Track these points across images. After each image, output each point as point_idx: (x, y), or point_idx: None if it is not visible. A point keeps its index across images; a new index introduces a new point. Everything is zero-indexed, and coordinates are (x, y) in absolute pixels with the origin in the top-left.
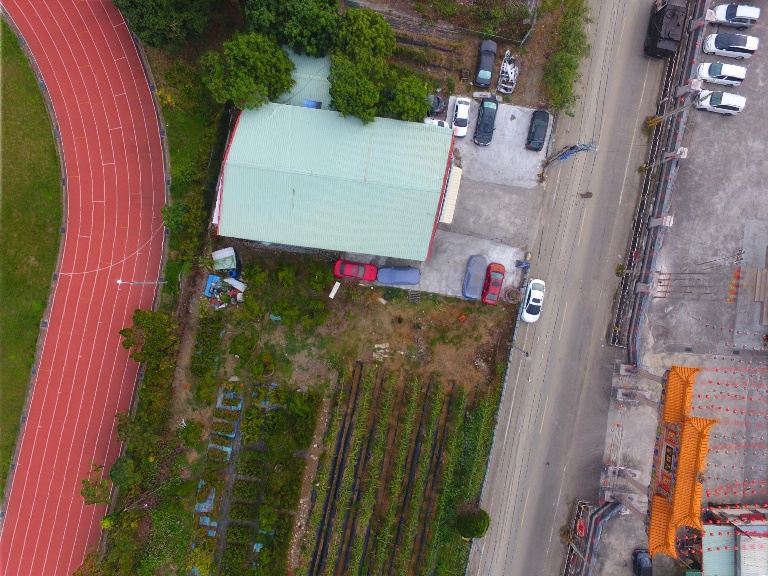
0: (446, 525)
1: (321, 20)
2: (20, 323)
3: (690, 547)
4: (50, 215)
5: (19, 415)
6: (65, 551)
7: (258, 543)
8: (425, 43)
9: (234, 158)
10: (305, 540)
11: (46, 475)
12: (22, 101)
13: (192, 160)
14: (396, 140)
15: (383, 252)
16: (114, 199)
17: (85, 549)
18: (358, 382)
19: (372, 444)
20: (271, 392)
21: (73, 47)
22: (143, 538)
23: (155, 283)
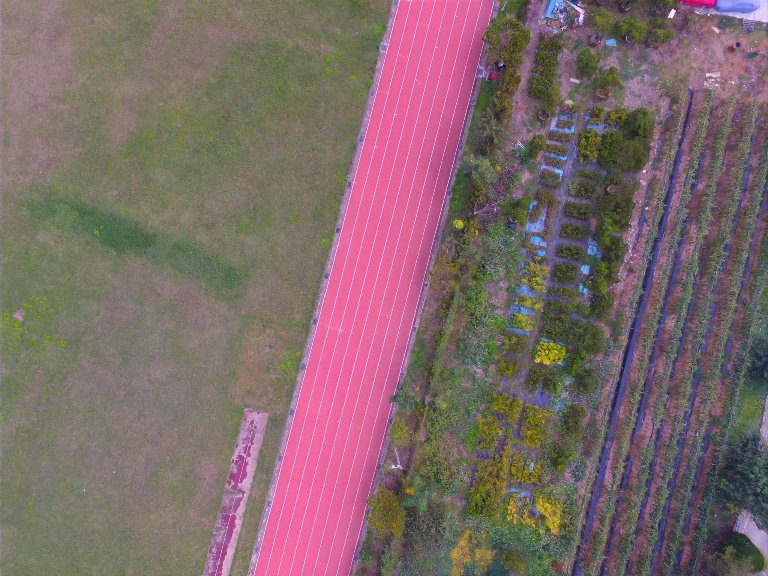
0: None
1: None
2: (362, 45)
3: None
4: None
5: (357, 135)
6: (396, 268)
7: (585, 265)
8: None
9: None
10: (632, 263)
11: (380, 194)
12: None
13: None
14: None
15: None
16: None
17: (415, 267)
18: (688, 110)
19: (700, 171)
20: (612, 109)
21: None
22: None
23: (490, 11)
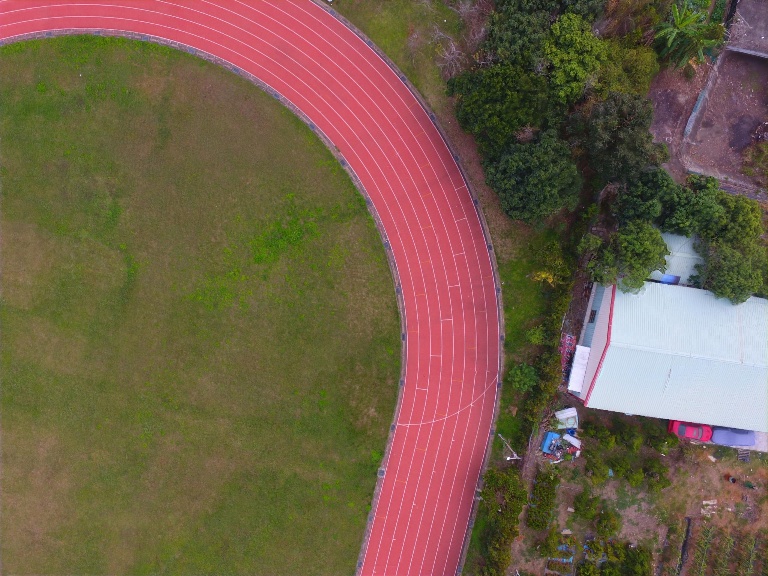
0: None
1: (715, 214)
2: (360, 472)
3: None
4: (391, 369)
5: (356, 560)
6: None
7: None
8: (760, 210)
9: (618, 340)
10: None
11: None
12: (368, 260)
13: (528, 318)
14: (762, 319)
15: (745, 426)
16: (451, 353)
17: None
18: (686, 537)
19: None
20: (610, 549)
21: (417, 209)
22: None
23: (487, 435)
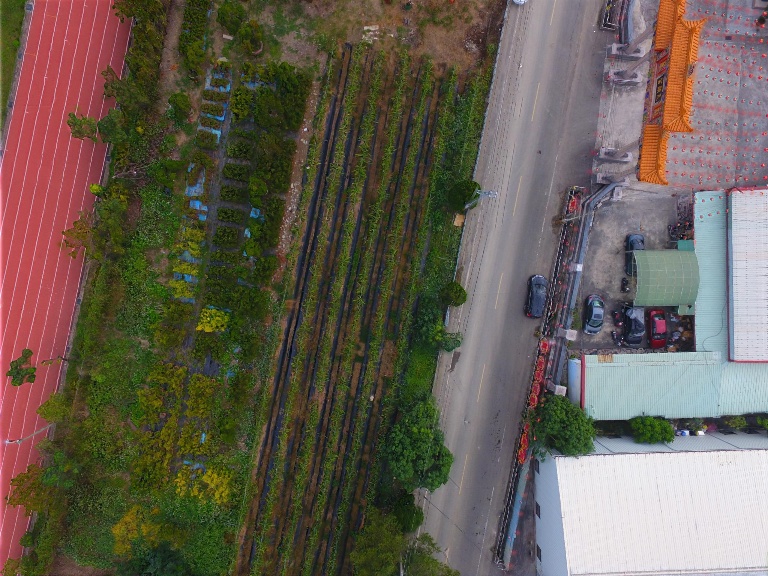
0: (438, 210)
1: None
2: (4, 4)
3: (682, 234)
4: None
5: (5, 100)
6: (55, 239)
7: (249, 228)
8: None
9: None
10: (296, 224)
11: (34, 161)
12: None
13: None
14: None
15: None
16: None
17: None
18: (348, 65)
19: None
20: (260, 65)
21: None
22: (133, 221)
23: None
